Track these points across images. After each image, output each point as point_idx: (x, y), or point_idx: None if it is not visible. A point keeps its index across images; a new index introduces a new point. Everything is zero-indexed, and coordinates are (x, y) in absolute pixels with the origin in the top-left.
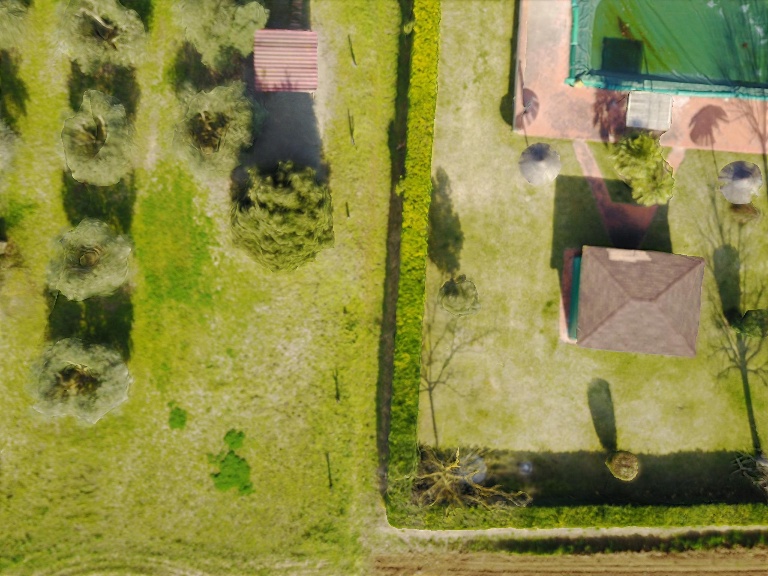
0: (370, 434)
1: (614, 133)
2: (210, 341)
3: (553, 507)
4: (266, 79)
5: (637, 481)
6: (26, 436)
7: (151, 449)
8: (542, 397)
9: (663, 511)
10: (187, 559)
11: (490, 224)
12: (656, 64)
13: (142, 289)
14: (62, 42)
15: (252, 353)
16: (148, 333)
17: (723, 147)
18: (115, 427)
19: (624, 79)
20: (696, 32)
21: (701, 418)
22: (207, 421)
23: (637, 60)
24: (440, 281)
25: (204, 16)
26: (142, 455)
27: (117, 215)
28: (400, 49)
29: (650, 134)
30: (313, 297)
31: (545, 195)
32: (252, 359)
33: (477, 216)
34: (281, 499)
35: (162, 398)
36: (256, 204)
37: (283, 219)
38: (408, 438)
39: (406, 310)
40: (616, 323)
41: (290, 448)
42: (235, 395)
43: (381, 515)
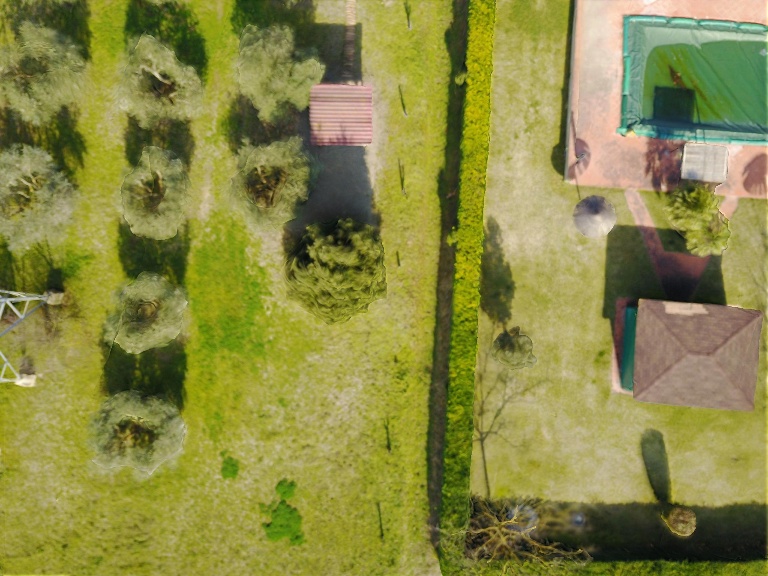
0: (421, 483)
1: (666, 182)
2: (262, 390)
3: (609, 561)
4: (321, 133)
5: (692, 533)
6: (81, 485)
7: (204, 498)
8: (595, 448)
9: (721, 567)
10: None
11: (541, 273)
12: (708, 113)
13: (195, 338)
14: (122, 99)
15: (304, 402)
16: (201, 382)
17: None
18: (168, 476)
19: (676, 129)
20: (748, 81)
21: (757, 470)
22: (259, 470)
23: (689, 109)
24: (491, 330)
25: (262, 73)
26: (195, 504)
27: (171, 265)
28: (450, 98)
29: (706, 187)
30: (364, 346)
31: (597, 245)
32: (304, 408)
33: (528, 265)
34: (332, 549)
35: (215, 447)
36: (316, 262)
37: (343, 277)
38: (462, 490)
39: (459, 361)
40: (673, 377)
41: (341, 497)
42: (287, 444)
43: (432, 565)
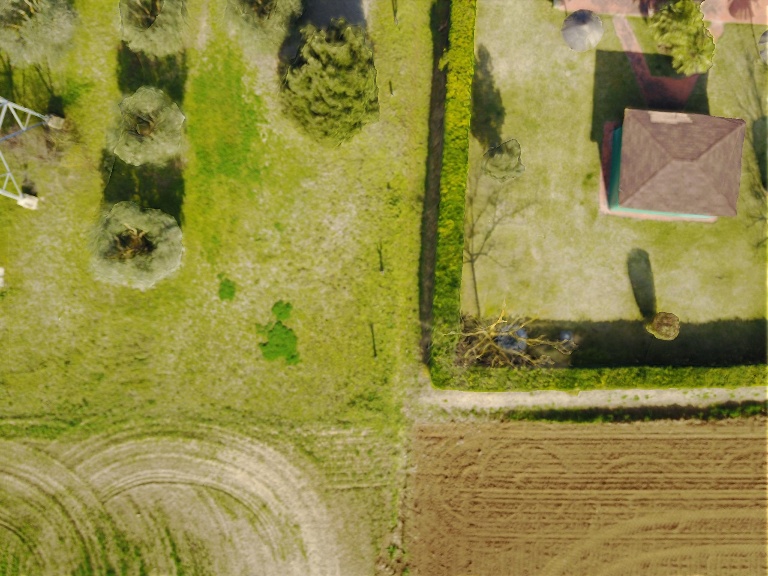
0: (413, 308)
1: (653, 8)
2: (258, 215)
3: (595, 368)
4: None
5: (677, 350)
6: (83, 305)
7: (202, 319)
8: (583, 268)
9: (704, 372)
10: (237, 425)
11: (531, 99)
12: None
13: (193, 164)
14: None
15: (299, 227)
16: (199, 207)
17: (762, 21)
18: (167, 297)
19: None
20: None
21: (740, 288)
22: (256, 292)
23: None
24: (482, 156)
25: None
26: (193, 324)
27: (169, 93)
28: None
29: None
30: (358, 173)
31: (585, 70)
32: (299, 233)
33: (518, 92)
34: (327, 368)
35: (212, 270)
36: (309, 58)
37: (335, 73)
38: (452, 302)
39: (450, 178)
40: (658, 183)
41: (336, 319)
42: (282, 267)
43: (424, 385)
